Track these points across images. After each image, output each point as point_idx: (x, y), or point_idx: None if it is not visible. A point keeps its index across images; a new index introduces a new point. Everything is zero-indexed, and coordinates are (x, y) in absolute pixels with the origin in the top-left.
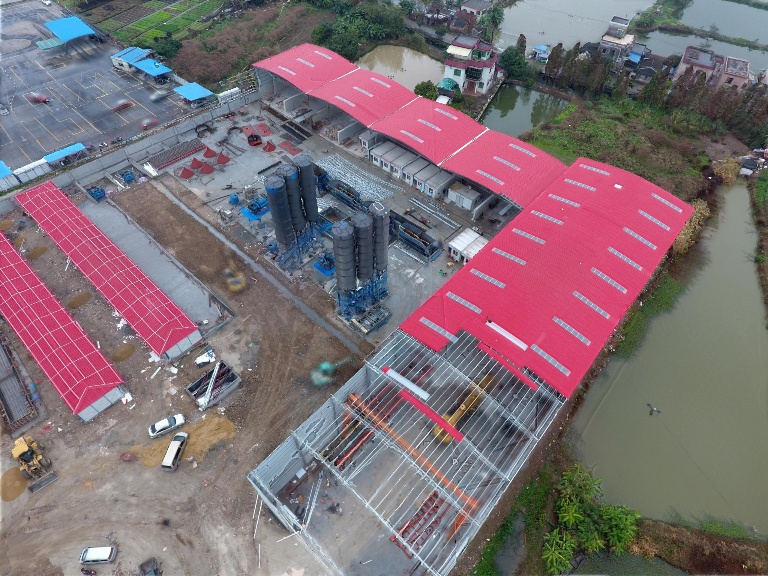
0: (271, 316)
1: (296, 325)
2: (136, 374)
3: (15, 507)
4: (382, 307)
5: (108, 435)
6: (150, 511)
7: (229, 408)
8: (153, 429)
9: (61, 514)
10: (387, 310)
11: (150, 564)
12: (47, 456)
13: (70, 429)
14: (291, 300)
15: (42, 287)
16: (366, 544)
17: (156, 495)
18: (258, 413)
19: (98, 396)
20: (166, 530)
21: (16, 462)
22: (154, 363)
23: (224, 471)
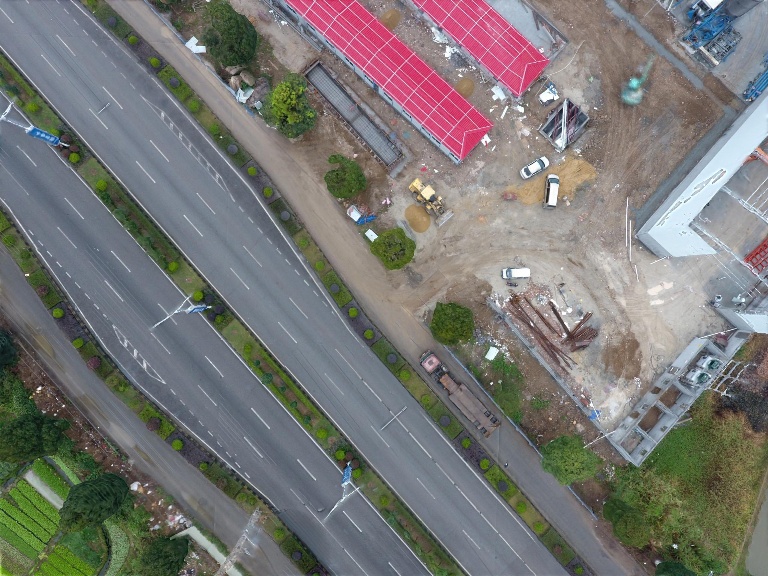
0: (606, 42)
1: (635, 54)
2: (485, 114)
3: (429, 237)
4: (733, 30)
5: (481, 176)
6: (541, 241)
7: (585, 150)
8: (528, 172)
9: (470, 243)
10: (740, 35)
11: (558, 279)
12: (436, 195)
13: (445, 170)
14: (624, 19)
15: (357, 5)
16: (721, 266)
17: (542, 228)
18: (614, 155)
19: (476, 141)
20: (559, 255)
21: (411, 200)
22: (499, 101)
23: (594, 209)
